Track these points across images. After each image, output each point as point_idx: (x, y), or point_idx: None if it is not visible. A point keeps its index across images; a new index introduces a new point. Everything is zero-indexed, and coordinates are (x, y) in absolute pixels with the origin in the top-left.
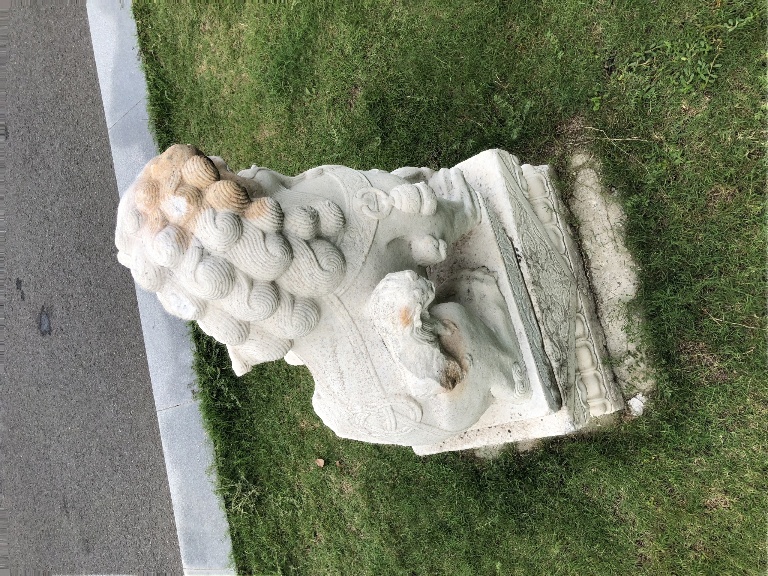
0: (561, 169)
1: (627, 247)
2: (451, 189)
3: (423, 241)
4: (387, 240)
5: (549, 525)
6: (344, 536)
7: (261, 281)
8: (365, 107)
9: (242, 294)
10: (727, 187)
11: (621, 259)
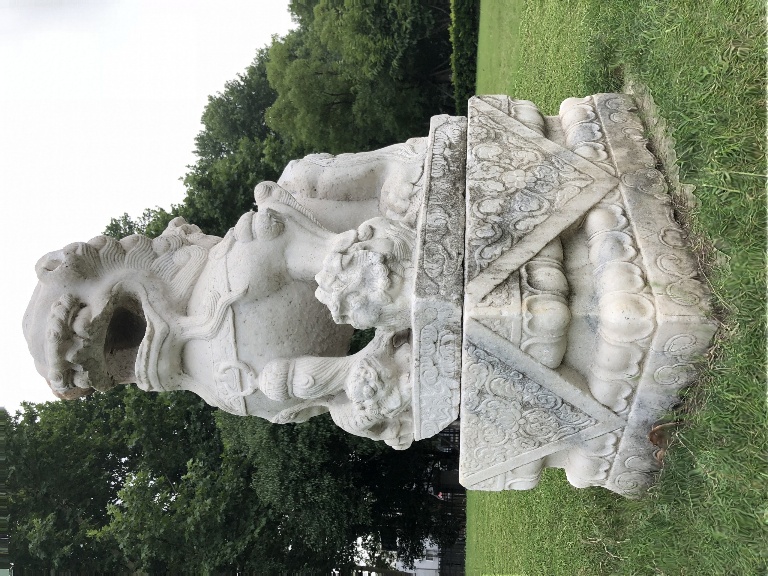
0: None
1: None
2: None
3: None
4: None
5: None
6: None
7: None
8: None
9: None
10: None
11: None
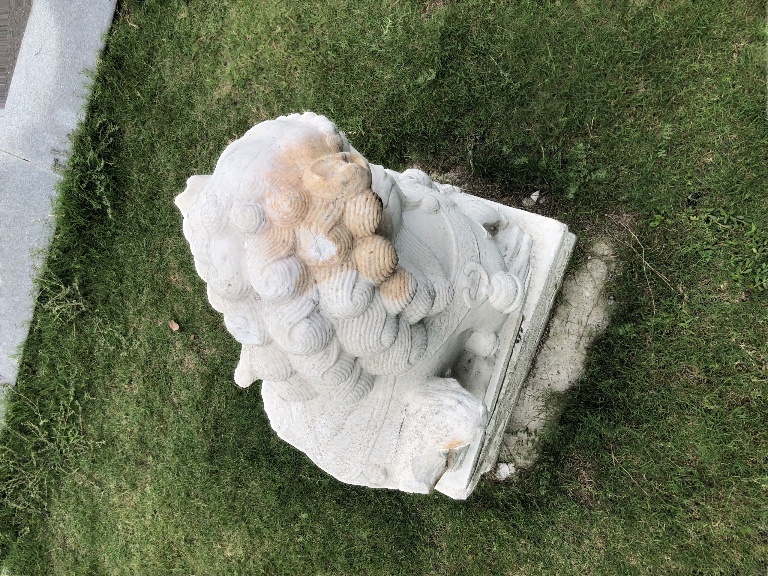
0: (582, 245)
1: (587, 352)
2: (515, 256)
3: (487, 338)
4: (463, 330)
5: (369, 511)
6: (162, 402)
7: (349, 355)
8: (439, 26)
9: (324, 363)
10: (701, 373)
11: (574, 355)
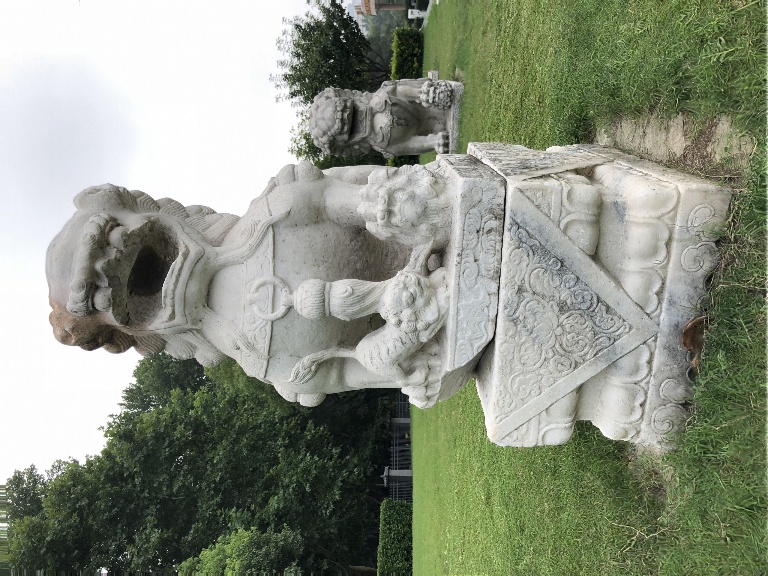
0: None
1: None
2: None
3: None
4: None
5: None
6: None
7: None
8: None
9: None
10: None
11: None
